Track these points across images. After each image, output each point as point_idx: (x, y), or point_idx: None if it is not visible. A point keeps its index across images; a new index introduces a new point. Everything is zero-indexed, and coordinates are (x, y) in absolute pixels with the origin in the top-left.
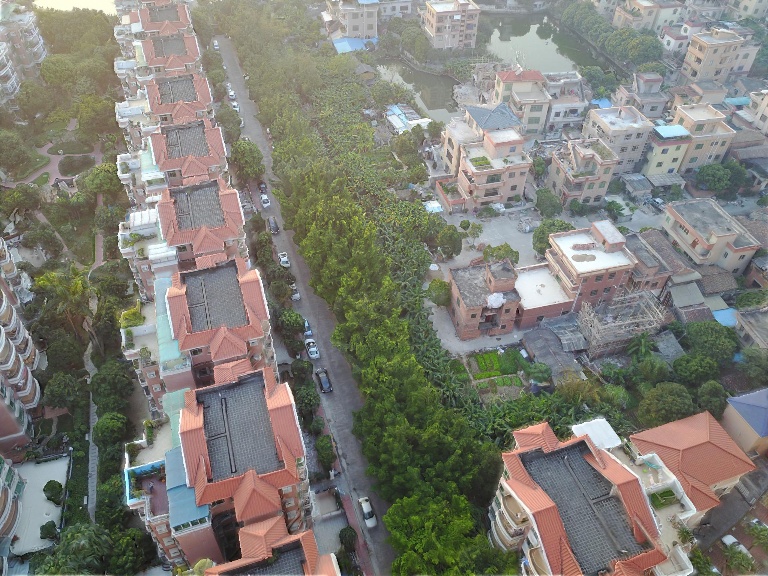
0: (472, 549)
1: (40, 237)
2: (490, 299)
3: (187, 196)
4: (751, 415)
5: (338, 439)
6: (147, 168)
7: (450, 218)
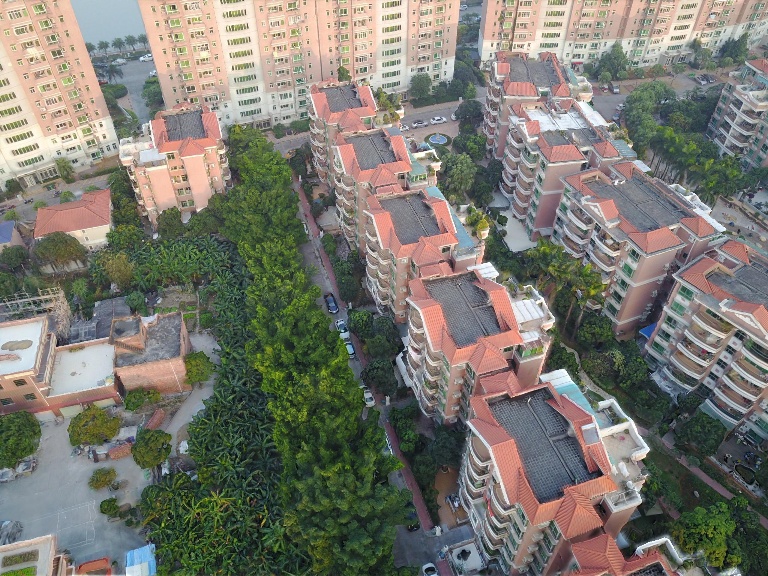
0: (247, 155)
1: (697, 418)
2: (153, 319)
3: (488, 333)
4: (6, 230)
5: (320, 266)
6: (571, 389)
7: (119, 558)
